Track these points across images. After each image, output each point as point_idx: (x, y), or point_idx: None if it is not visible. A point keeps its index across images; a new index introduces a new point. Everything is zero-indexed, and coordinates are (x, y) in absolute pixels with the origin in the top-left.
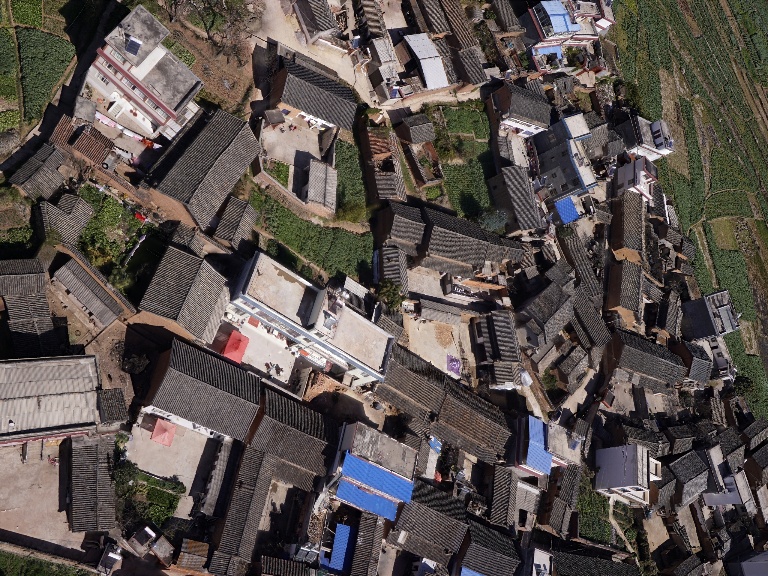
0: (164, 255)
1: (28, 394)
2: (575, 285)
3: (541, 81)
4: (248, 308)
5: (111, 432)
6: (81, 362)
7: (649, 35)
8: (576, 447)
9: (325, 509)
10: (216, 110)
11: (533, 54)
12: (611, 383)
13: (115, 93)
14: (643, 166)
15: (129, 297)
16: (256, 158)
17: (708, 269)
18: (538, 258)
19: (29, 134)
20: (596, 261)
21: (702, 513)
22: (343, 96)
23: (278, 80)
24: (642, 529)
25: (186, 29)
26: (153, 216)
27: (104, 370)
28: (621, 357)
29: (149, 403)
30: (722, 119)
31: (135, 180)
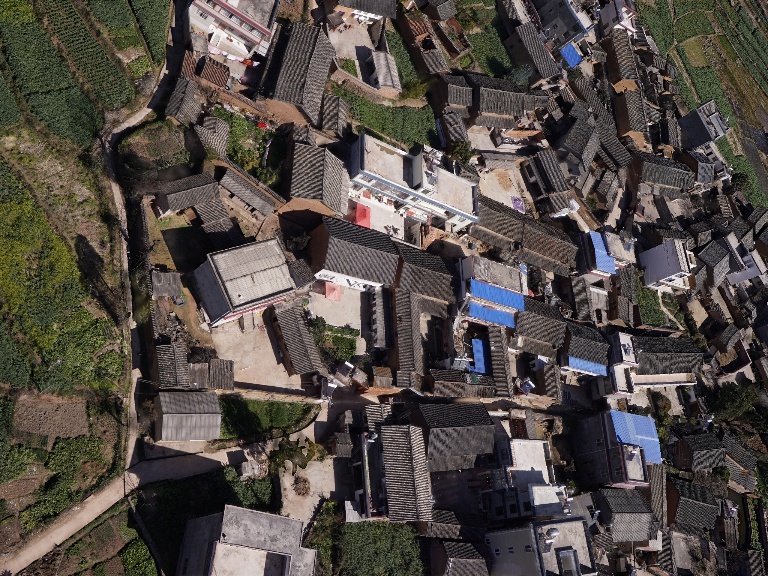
0: (294, 151)
1: (244, 274)
2: (594, 119)
3: None
4: (365, 182)
5: (304, 294)
6: (268, 244)
7: None
8: (630, 249)
9: (461, 329)
10: None
11: None
12: (638, 197)
13: (211, 25)
14: (623, 3)
15: None
16: None
17: (689, 87)
18: (558, 102)
19: (160, 74)
20: (602, 96)
21: (729, 291)
22: None
23: None
24: (688, 311)
25: None
26: (270, 123)
27: None
28: (643, 173)
29: None
30: None
31: (248, 96)
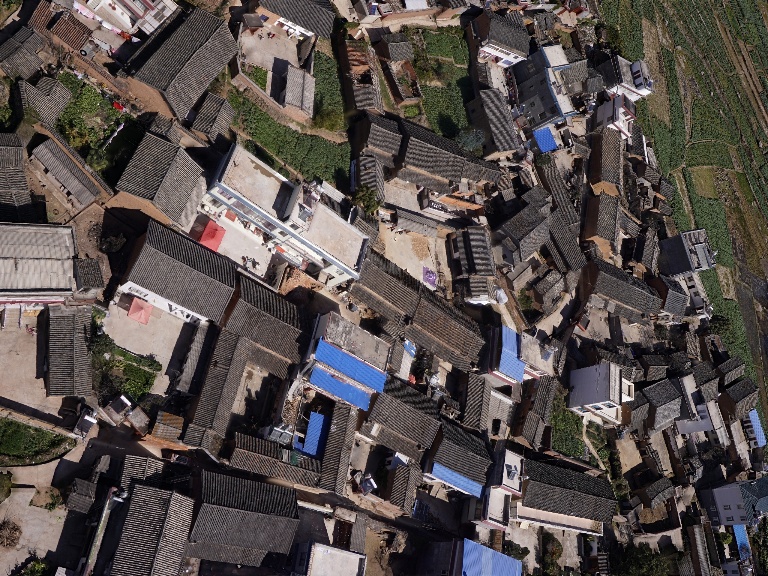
0: (141, 141)
1: (5, 255)
2: (552, 211)
3: (522, 16)
4: (224, 199)
5: (87, 301)
6: (58, 232)
7: None
8: (549, 359)
9: (299, 396)
10: (194, 9)
11: None
12: (586, 308)
13: None
14: (622, 103)
15: (107, 181)
16: (234, 60)
17: (687, 214)
18: (516, 184)
19: (8, 19)
20: (574, 193)
21: (675, 440)
22: (321, 5)
23: None
24: (615, 449)
25: None
26: (131, 107)
27: (82, 249)
28: (596, 283)
29: None
30: (704, 72)
31: (113, 71)
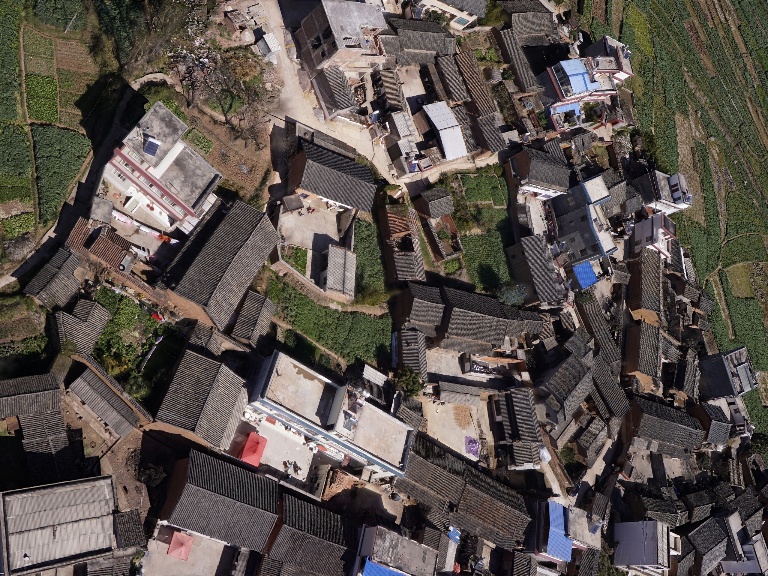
0: (181, 360)
1: (43, 524)
2: (594, 354)
3: (559, 139)
4: (266, 409)
5: (127, 555)
6: (97, 484)
7: (665, 79)
8: (596, 530)
9: None
10: None
11: (551, 113)
12: (629, 452)
13: (132, 188)
14: (661, 224)
15: (145, 403)
16: (274, 246)
17: (724, 320)
18: (556, 326)
19: (44, 237)
20: (614, 323)
21: None
22: (362, 178)
23: (297, 163)
24: None
25: (204, 115)
26: (170, 314)
27: (120, 482)
28: (640, 426)
29: (166, 519)
30: (737, 161)
31: (152, 278)
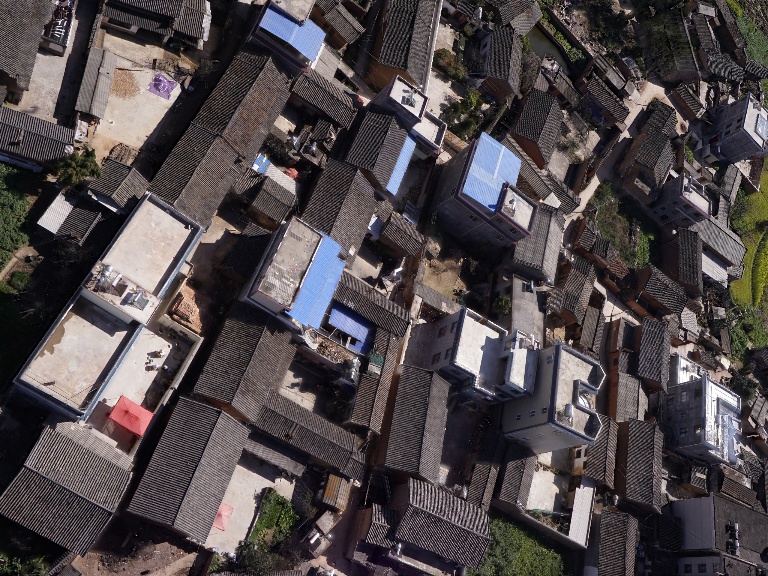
0: (6, 517)
1: None
2: None
3: None
4: None
5: None
6: None
7: None
8: None
9: (317, 336)
10: None
11: None
12: None
13: None
14: None
15: (49, 554)
16: None
17: None
18: None
19: None
20: None
21: None
22: None
23: None
24: None
25: None
26: None
27: None
28: None
29: None
30: None
31: None
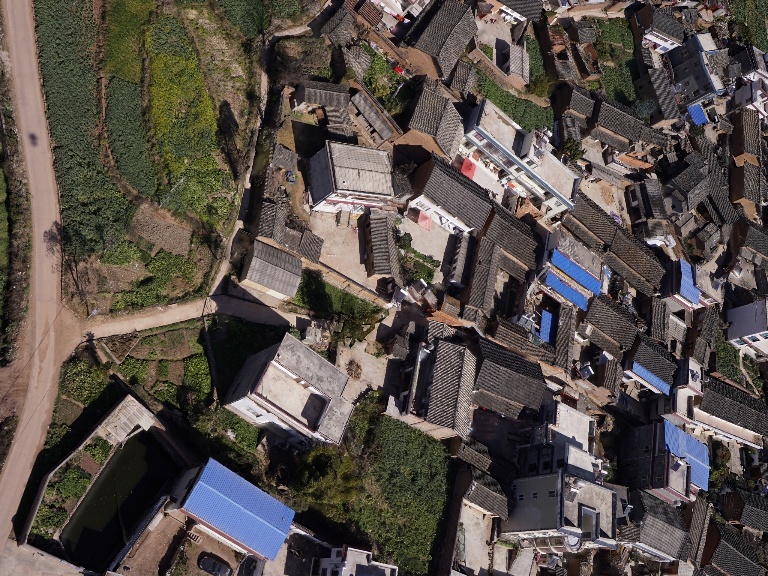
0: (421, 94)
1: (352, 166)
2: None
3: None
4: (477, 141)
5: (399, 206)
6: (379, 154)
7: None
8: (718, 289)
9: (535, 296)
10: None
11: None
12: (738, 259)
13: None
14: (760, 86)
15: None
16: None
17: None
18: (675, 150)
19: (325, 4)
20: (721, 163)
21: None
22: None
23: None
24: (767, 380)
25: None
26: (406, 71)
27: None
28: (747, 236)
29: None
30: None
31: None
